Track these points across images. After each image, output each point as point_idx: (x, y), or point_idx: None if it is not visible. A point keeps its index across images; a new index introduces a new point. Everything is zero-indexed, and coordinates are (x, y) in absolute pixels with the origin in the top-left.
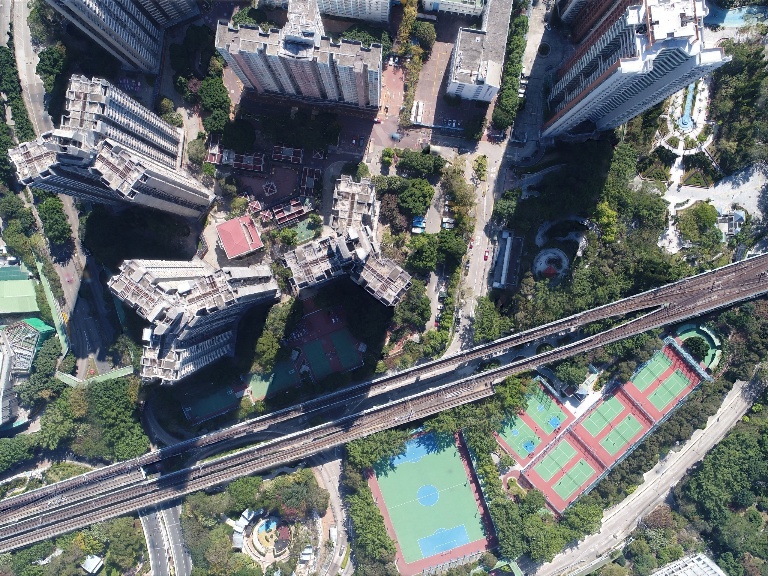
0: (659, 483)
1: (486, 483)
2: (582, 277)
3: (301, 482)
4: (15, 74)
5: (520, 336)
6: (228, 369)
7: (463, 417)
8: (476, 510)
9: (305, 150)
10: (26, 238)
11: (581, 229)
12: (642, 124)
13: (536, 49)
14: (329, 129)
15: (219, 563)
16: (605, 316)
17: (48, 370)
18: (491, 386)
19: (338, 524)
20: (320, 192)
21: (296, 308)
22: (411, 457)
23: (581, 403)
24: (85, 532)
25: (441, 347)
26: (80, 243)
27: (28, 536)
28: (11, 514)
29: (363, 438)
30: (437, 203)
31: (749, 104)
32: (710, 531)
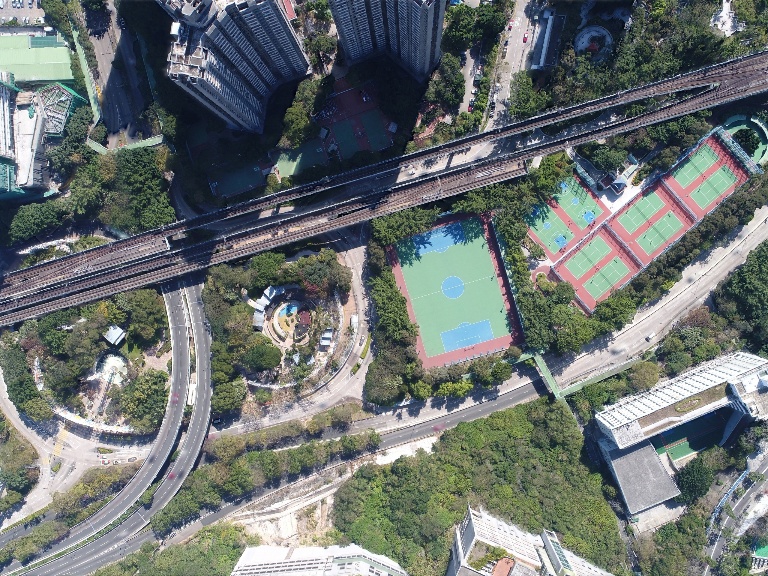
0: (698, 286)
1: (514, 274)
2: (626, 51)
3: (324, 261)
4: None
5: (557, 113)
6: (256, 143)
7: (493, 197)
8: (502, 305)
9: None
10: (63, 5)
11: None
12: None
13: None
14: None
15: (238, 334)
16: (649, 96)
17: (79, 134)
18: (524, 166)
19: (360, 313)
20: None
21: (327, 80)
22: (437, 247)
23: (618, 198)
24: (109, 303)
25: (474, 133)
26: (116, 16)
27: (54, 304)
28: (39, 281)
29: (389, 213)
30: None
31: None
32: (751, 330)
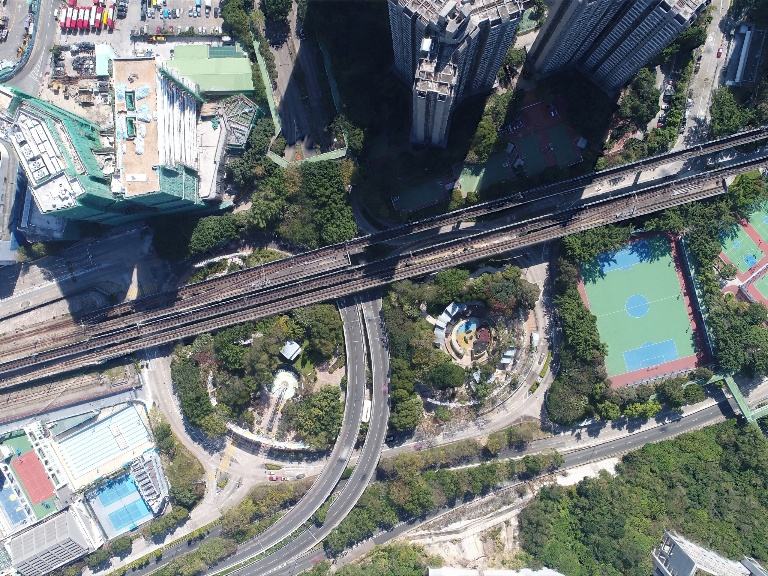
0: None
1: (704, 294)
2: None
3: (510, 278)
4: None
5: (760, 130)
6: (442, 157)
7: (691, 215)
8: (688, 325)
9: None
10: (246, 14)
11: None
12: None
13: None
14: None
15: (424, 352)
16: None
17: (262, 147)
18: (723, 184)
19: (540, 331)
20: None
21: (518, 94)
22: (622, 264)
23: None
24: (286, 317)
25: (663, 149)
26: (295, 26)
27: (229, 318)
28: (214, 295)
29: (583, 230)
30: None
31: None
32: None
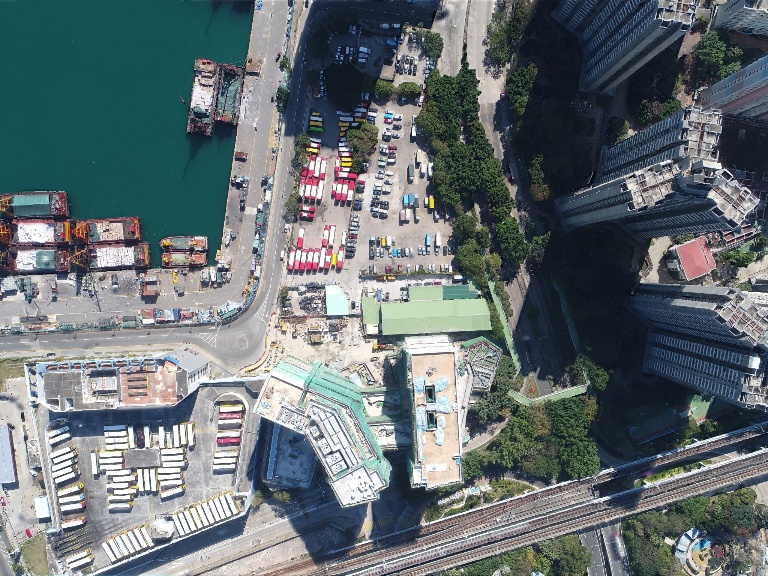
0: None
1: None
2: None
3: (748, 502)
4: (477, 95)
5: None
6: None
7: None
8: None
9: None
10: (482, 257)
11: None
12: None
13: None
14: None
15: None
16: None
17: (507, 389)
18: None
19: None
20: None
21: None
22: None
23: None
24: (530, 549)
25: None
26: (524, 262)
27: (474, 552)
28: (458, 530)
29: None
30: None
31: None
32: None
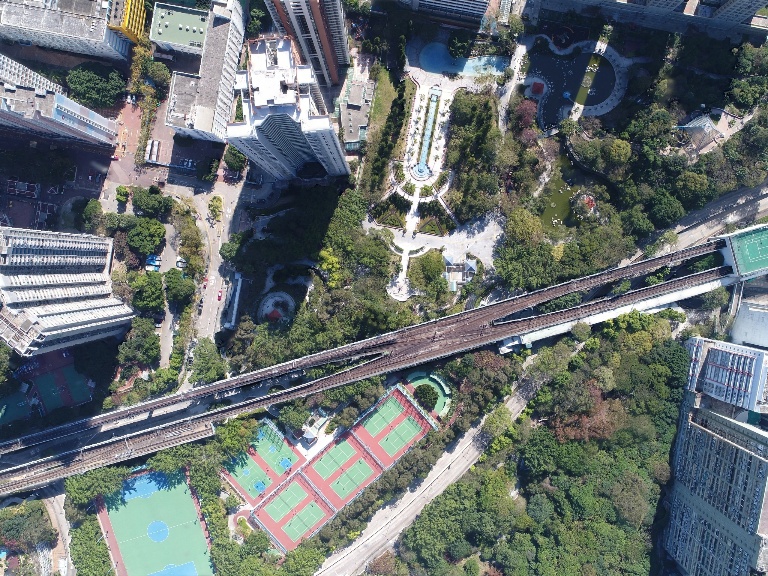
0: (388, 528)
1: None
2: (300, 323)
3: (24, 514)
4: None
5: None
6: None
7: (181, 457)
8: (206, 548)
9: (42, 184)
10: None
11: (300, 275)
12: (372, 171)
13: None
14: (54, 166)
15: None
16: (326, 362)
17: None
18: (211, 427)
19: (69, 556)
20: (50, 227)
21: None
22: (142, 493)
23: (313, 446)
24: None
25: (174, 385)
26: None
27: None
28: None
29: (80, 474)
30: (173, 242)
31: (476, 155)
32: None
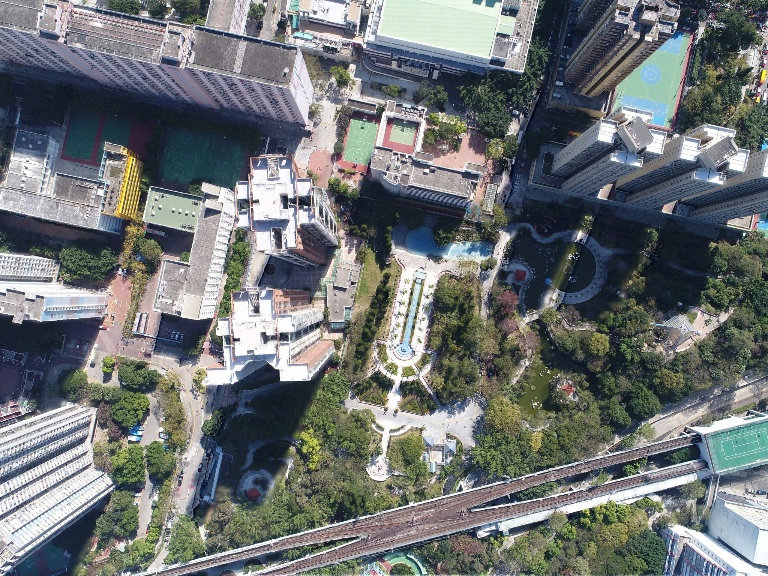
0: None
1: None
2: (279, 505)
3: None
4: None
5: None
6: None
7: None
8: None
9: (30, 352)
10: None
11: (280, 457)
12: (355, 352)
13: (263, 269)
14: (42, 341)
15: None
16: (303, 543)
17: None
18: None
19: None
20: (35, 397)
21: None
22: None
23: None
24: None
25: (150, 555)
26: None
27: None
28: None
29: None
30: (157, 411)
31: (458, 342)
32: None
